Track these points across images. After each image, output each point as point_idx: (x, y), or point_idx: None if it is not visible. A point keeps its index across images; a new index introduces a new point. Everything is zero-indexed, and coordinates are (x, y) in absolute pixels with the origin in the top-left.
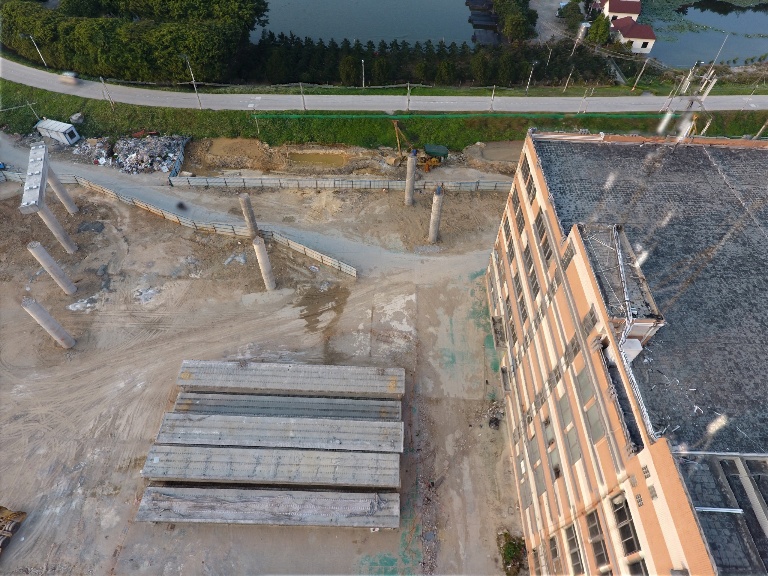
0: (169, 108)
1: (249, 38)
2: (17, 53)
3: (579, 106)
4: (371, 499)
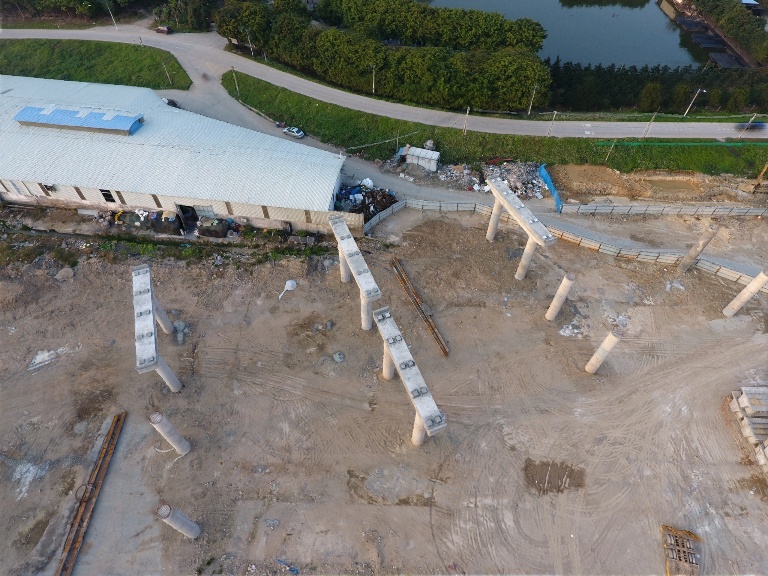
0: (518, 136)
1: None
2: (326, 79)
3: None
4: None
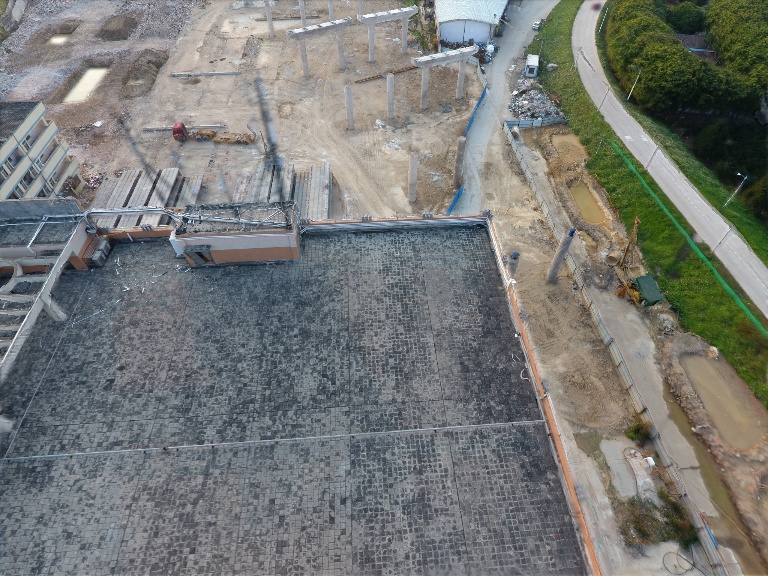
0: (587, 96)
1: (757, 112)
2: None
3: None
4: None
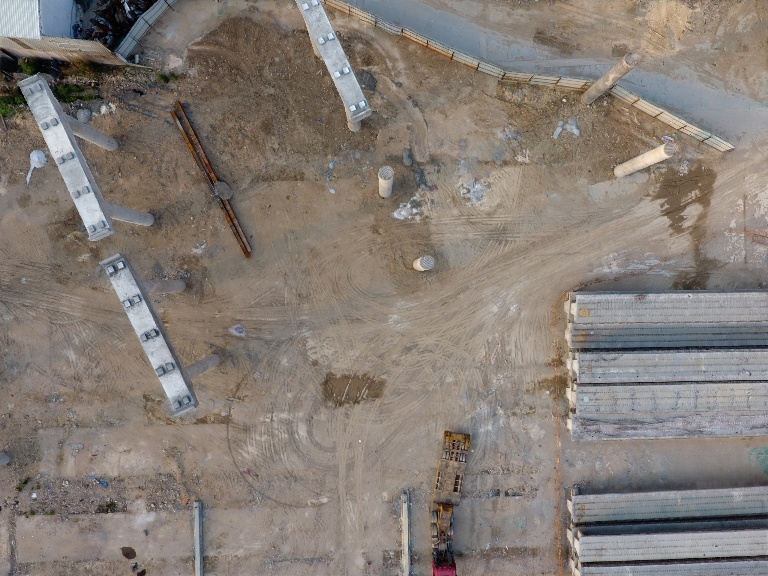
0: None
1: None
2: None
3: None
4: None
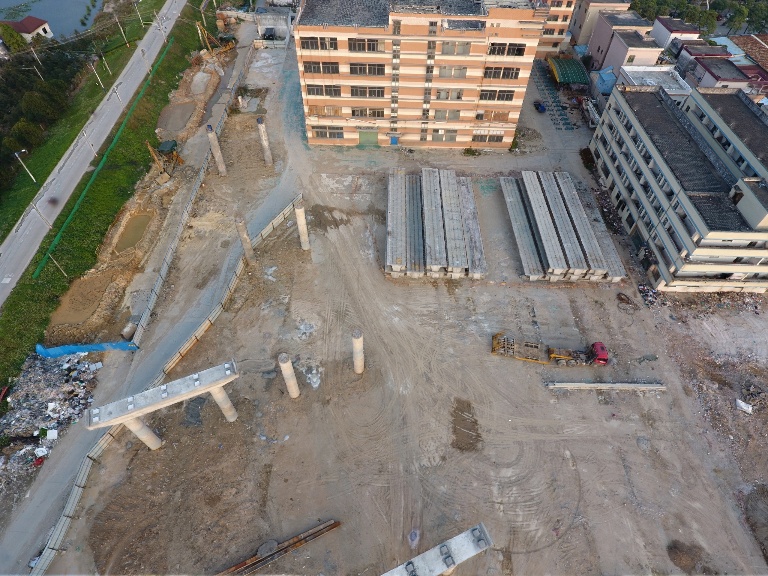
0: None
1: None
2: None
3: (137, 72)
4: (460, 185)
